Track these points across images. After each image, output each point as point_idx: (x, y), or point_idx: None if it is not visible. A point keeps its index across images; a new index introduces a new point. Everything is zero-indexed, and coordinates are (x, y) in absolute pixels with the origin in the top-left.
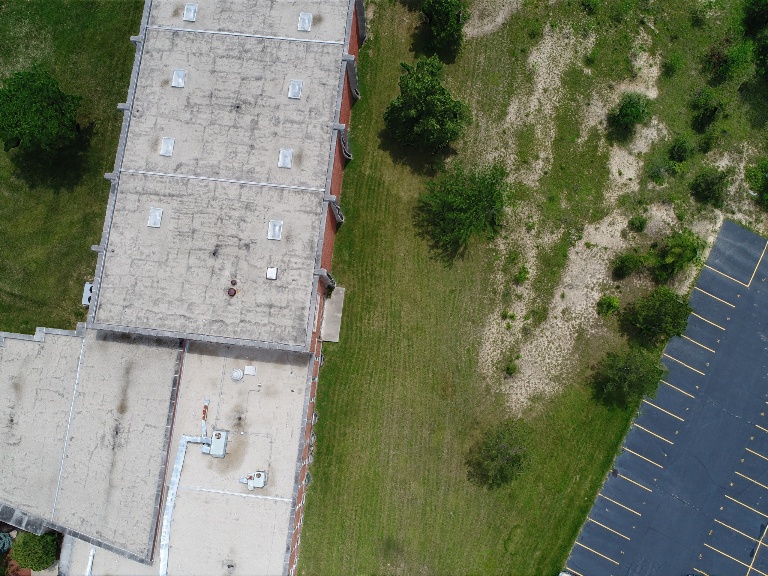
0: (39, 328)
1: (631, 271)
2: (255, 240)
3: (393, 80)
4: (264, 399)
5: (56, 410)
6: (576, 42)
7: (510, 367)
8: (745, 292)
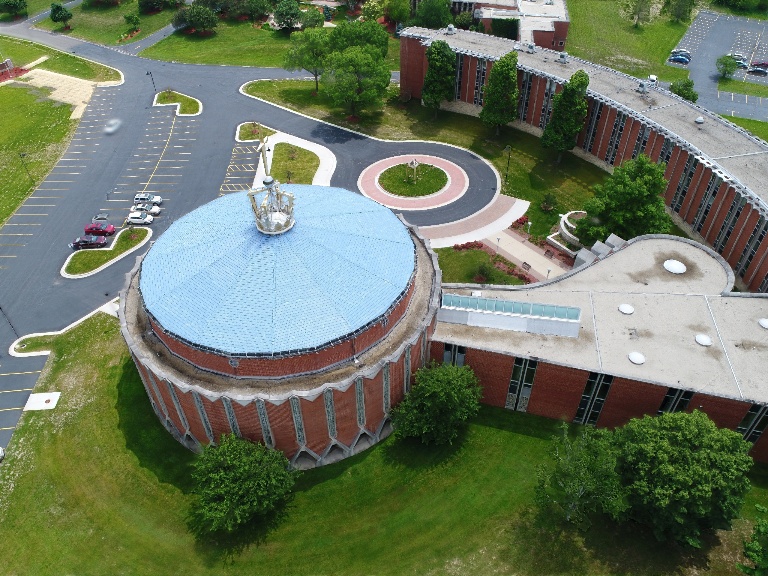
0: None
1: (669, 5)
2: None
3: None
4: None
5: None
6: None
7: None
8: None
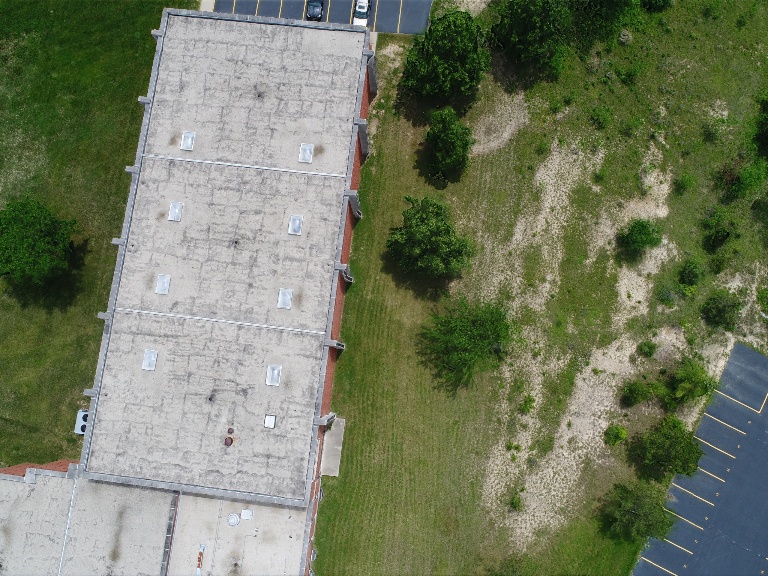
0: (29, 469)
1: (640, 402)
2: (253, 385)
3: (396, 199)
4: (261, 545)
5: (46, 556)
6: (585, 158)
7: (514, 501)
8: (756, 419)
